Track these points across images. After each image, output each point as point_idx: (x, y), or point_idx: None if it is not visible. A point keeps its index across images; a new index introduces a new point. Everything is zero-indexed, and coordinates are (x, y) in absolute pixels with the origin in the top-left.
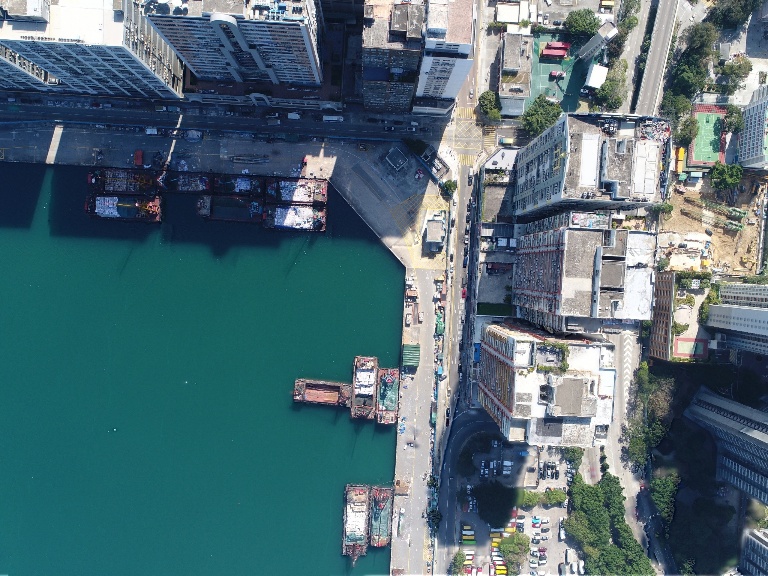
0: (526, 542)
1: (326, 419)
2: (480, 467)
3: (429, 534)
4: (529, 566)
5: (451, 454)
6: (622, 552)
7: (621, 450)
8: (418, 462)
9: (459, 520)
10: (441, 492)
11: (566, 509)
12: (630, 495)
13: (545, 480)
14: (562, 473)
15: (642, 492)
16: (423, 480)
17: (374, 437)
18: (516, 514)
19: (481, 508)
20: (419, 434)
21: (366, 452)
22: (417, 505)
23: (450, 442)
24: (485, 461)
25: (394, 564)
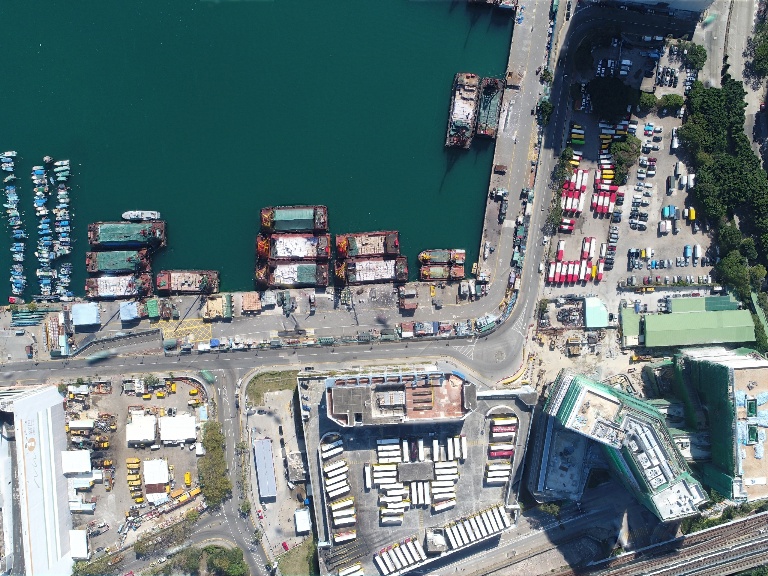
0: (639, 141)
1: (442, 4)
2: (597, 66)
3: (537, 132)
4: (636, 177)
5: (568, 50)
6: (738, 159)
7: (744, 64)
8: (533, 55)
9: (569, 120)
10: (553, 89)
11: (681, 120)
12: (749, 113)
13: (662, 87)
14: (681, 82)
15: (762, 110)
16: (536, 75)
17: (489, 28)
18: (629, 118)
19: (598, 95)
20: (537, 25)
21: (480, 43)
22: (527, 100)
23: (568, 37)
24: (603, 60)
25: (497, 161)
